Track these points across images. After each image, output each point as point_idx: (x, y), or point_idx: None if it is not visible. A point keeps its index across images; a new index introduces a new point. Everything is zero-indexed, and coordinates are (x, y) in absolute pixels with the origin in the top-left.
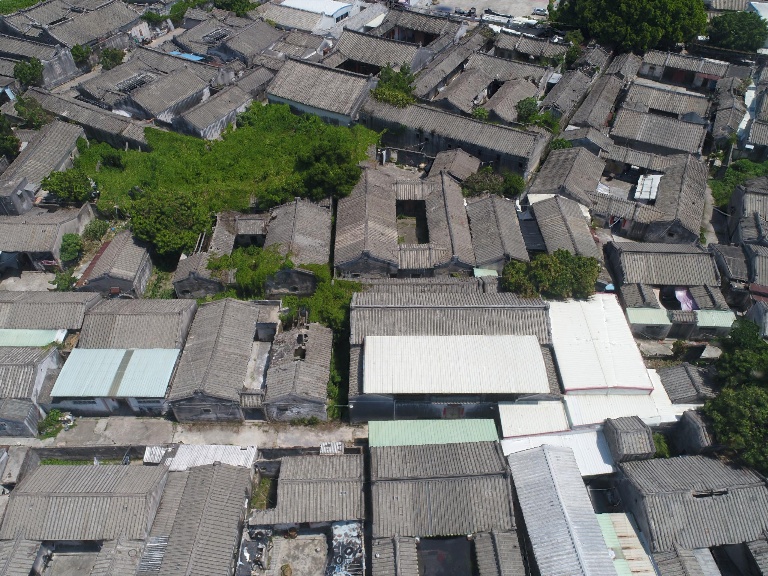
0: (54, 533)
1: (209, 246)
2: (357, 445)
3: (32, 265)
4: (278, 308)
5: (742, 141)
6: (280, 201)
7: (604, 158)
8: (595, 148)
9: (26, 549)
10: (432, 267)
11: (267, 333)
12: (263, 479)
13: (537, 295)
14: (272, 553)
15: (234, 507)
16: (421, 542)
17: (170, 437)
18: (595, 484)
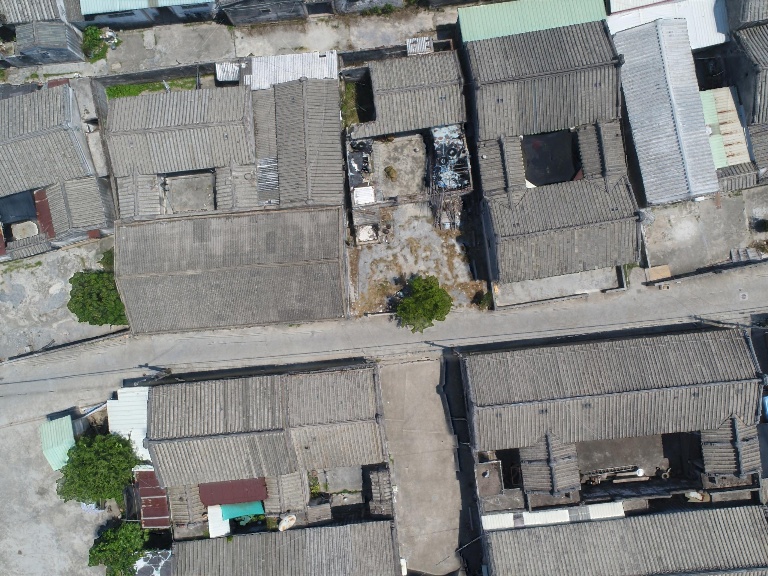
0: (165, 166)
1: None
2: (440, 34)
3: None
4: None
5: None
6: None
7: None
8: None
9: (146, 183)
10: None
11: None
12: (347, 85)
13: None
14: (373, 157)
15: (333, 123)
16: (524, 139)
17: (231, 45)
18: (697, 53)
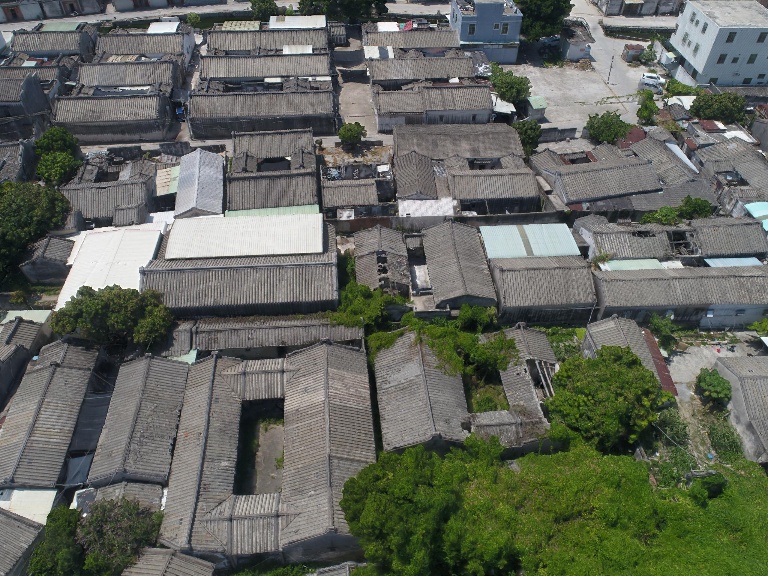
0: None
1: None
2: None
3: None
4: None
5: None
6: None
7: None
8: None
9: None
10: None
11: None
12: None
13: None
14: None
15: None
16: None
17: None
18: None
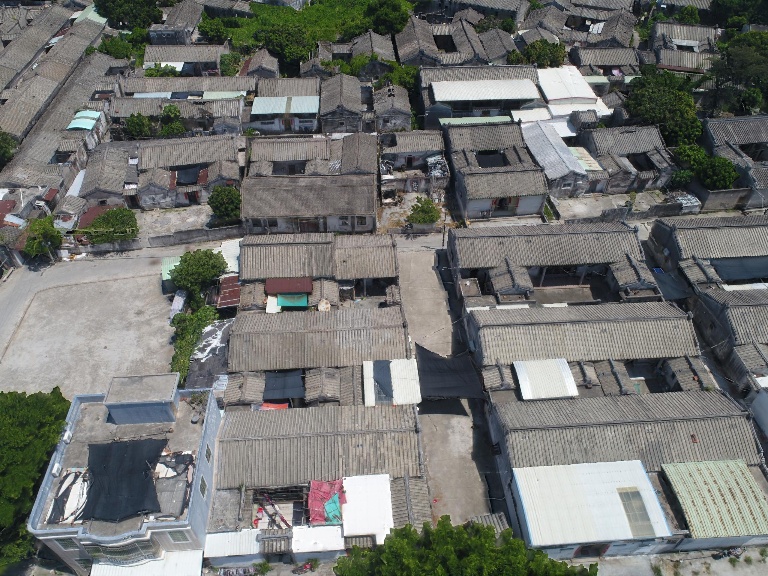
0: (280, 158)
1: (318, 56)
2: None
3: (200, 75)
4: (370, 83)
5: (659, 5)
6: (358, 34)
7: (567, 14)
8: (561, 9)
9: (267, 164)
10: (462, 62)
11: (365, 97)
12: None
13: (529, 64)
14: None
15: (373, 148)
16: (476, 155)
17: None
18: None
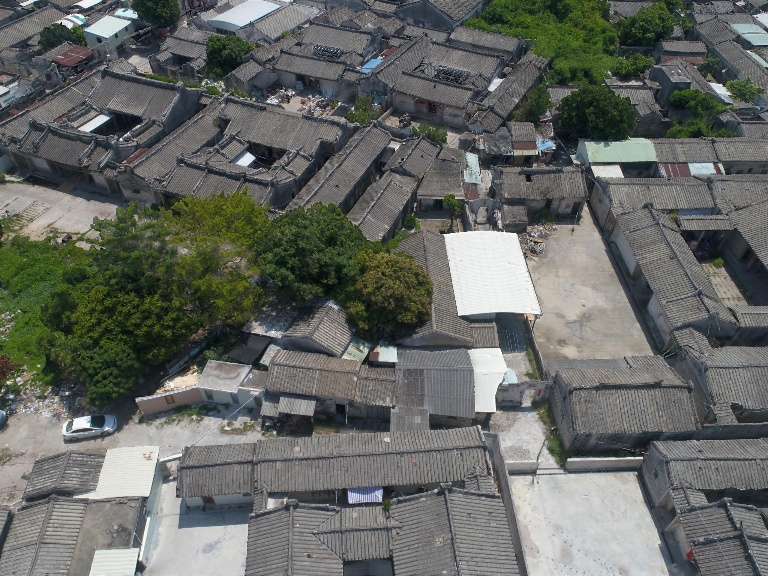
0: None
1: None
2: None
3: None
4: None
5: None
6: None
7: None
8: None
9: None
10: None
11: None
12: None
13: None
14: None
15: None
16: None
17: None
18: None
